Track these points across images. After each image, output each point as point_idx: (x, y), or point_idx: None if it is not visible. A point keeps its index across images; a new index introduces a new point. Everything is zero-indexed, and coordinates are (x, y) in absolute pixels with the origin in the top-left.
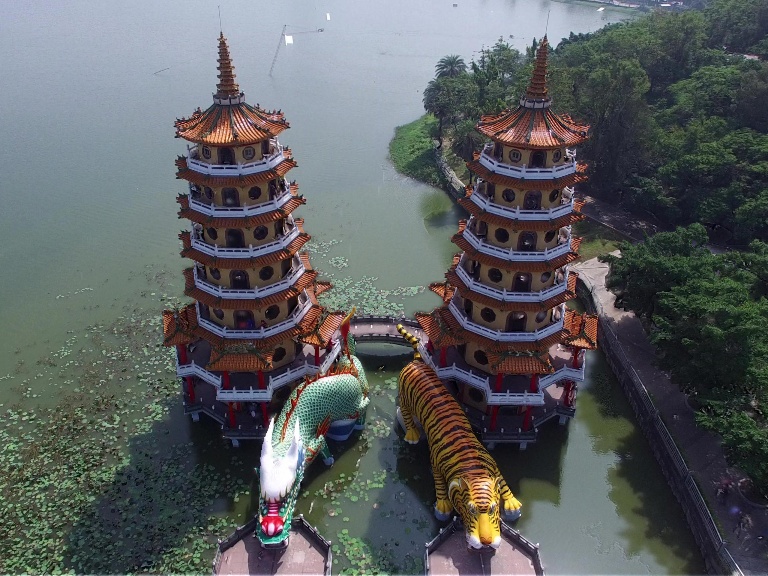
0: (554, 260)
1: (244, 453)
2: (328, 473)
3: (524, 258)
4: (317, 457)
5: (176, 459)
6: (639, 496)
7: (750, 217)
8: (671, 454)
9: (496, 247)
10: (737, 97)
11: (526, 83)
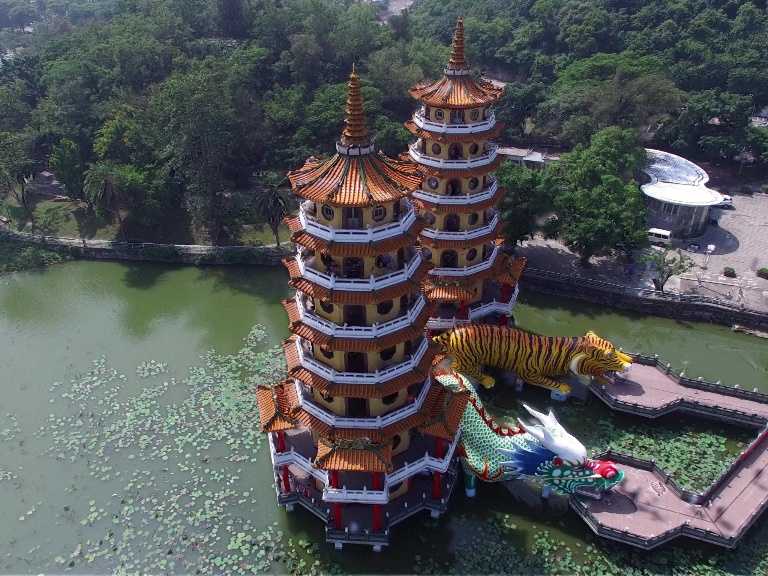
0: None
1: (453, 509)
2: None
3: (493, 192)
4: None
5: (441, 574)
6: (562, 309)
7: (389, 140)
8: (546, 278)
9: (479, 193)
10: (296, 66)
11: (198, 96)
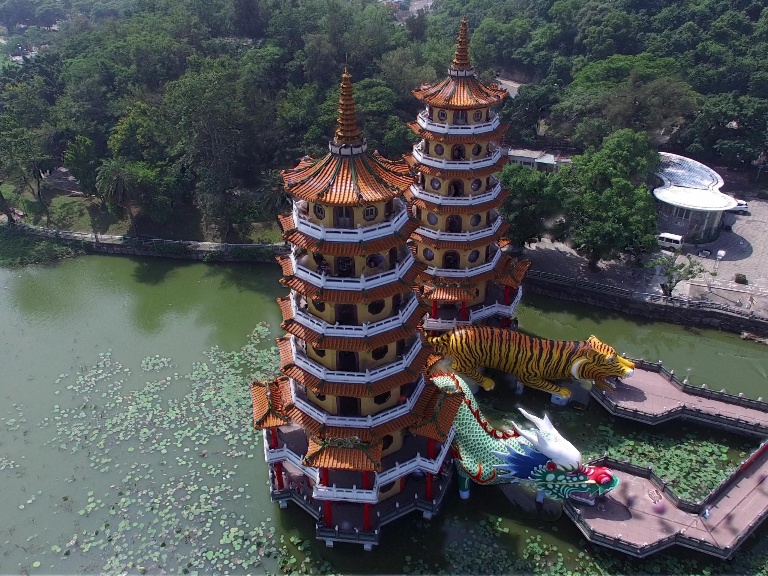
0: None
1: (446, 511)
2: None
3: (496, 193)
4: None
5: (430, 575)
6: (567, 313)
7: (400, 141)
8: (553, 281)
9: (482, 195)
10: (309, 65)
11: (209, 94)
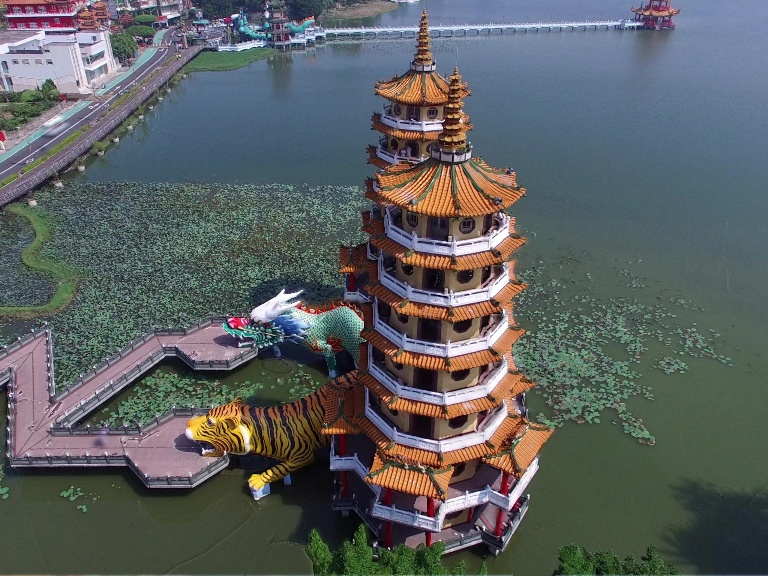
0: (383, 337)
1: None
2: (322, 376)
3: None
4: (323, 357)
5: None
6: None
7: None
8: None
9: None
10: None
11: None
